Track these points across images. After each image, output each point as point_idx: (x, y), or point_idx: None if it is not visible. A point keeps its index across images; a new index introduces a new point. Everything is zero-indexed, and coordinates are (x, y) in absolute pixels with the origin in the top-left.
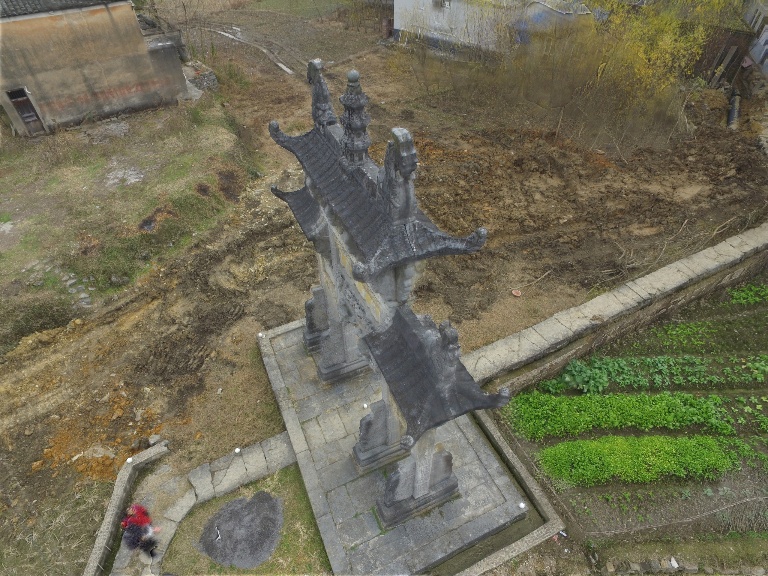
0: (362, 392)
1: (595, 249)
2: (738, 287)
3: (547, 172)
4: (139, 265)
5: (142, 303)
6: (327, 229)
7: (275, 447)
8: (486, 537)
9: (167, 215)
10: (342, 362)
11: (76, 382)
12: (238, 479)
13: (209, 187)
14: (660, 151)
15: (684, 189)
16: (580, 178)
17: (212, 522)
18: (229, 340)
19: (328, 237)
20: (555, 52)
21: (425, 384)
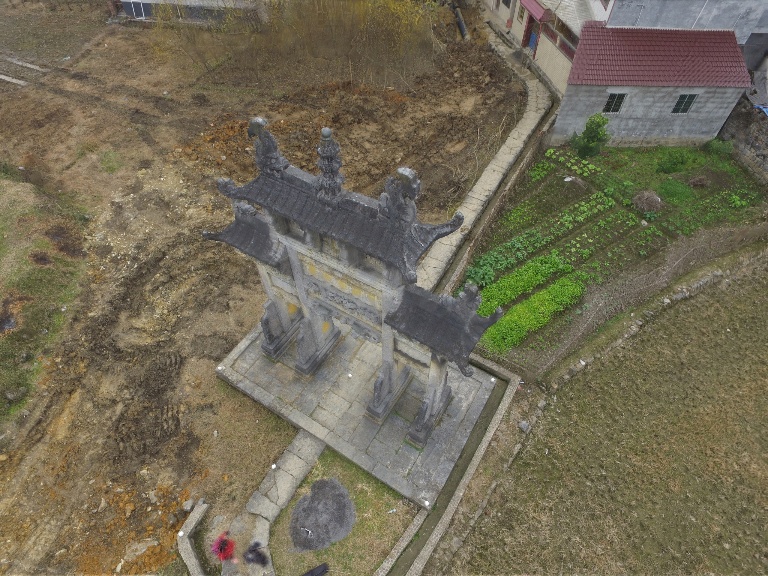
0: (340, 367)
1: (432, 175)
2: (531, 168)
3: (363, 121)
4: (26, 368)
5: (61, 403)
6: (286, 251)
7: (302, 446)
8: (481, 413)
9: (21, 303)
10: (315, 352)
11: (54, 511)
12: (291, 486)
13: (45, 253)
14: (433, 75)
15: (464, 103)
16: (390, 118)
17: (294, 527)
18: (188, 388)
19: (287, 257)
20: (327, 10)
21: (453, 330)
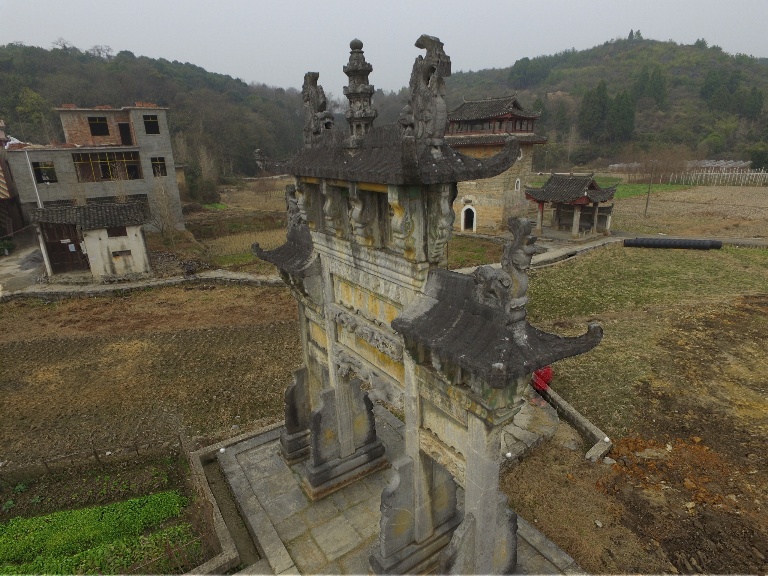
0: None
1: None
2: None
3: None
4: None
5: None
6: None
7: None
8: None
9: None
10: None
11: None
12: None
13: None
14: None
15: None
16: None
17: None
18: None
19: None
20: None
21: None
